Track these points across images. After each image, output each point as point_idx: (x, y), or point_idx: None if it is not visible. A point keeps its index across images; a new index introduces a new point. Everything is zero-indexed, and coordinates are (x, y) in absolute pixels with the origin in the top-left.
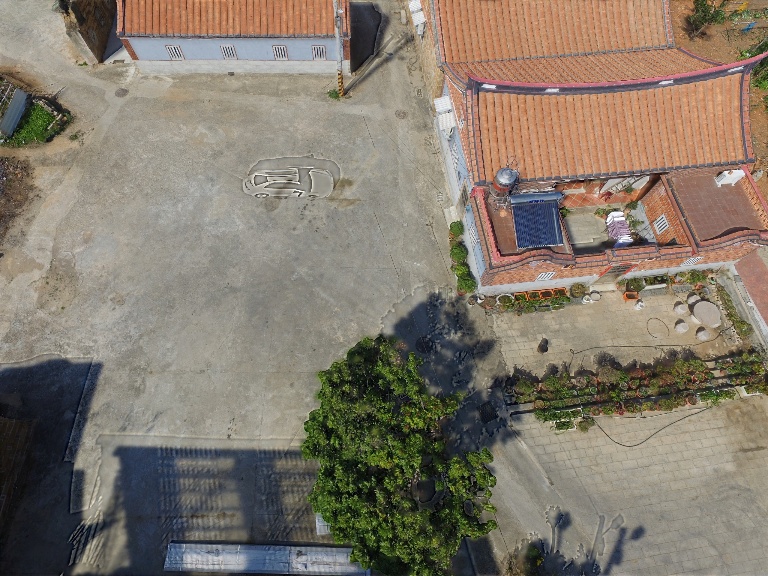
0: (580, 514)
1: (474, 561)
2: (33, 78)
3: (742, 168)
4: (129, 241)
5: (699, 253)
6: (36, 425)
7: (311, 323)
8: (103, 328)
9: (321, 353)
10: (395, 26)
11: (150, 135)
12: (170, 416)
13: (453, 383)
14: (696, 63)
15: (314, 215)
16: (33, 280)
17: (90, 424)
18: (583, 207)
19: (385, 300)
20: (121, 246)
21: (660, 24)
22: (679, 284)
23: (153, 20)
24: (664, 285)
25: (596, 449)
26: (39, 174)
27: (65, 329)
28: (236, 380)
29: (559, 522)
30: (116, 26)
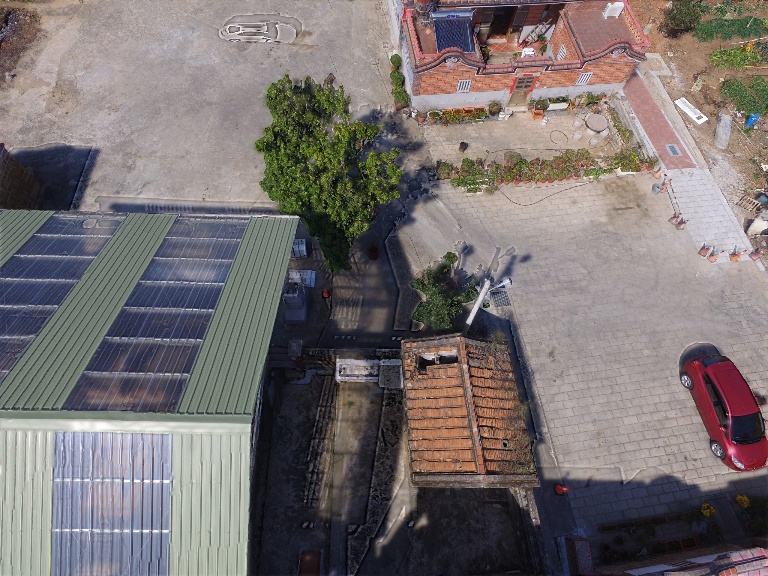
0: (481, 246)
1: (395, 274)
2: None
3: (624, 3)
4: (122, 69)
5: (586, 66)
6: (46, 188)
7: None
8: (100, 127)
9: None
10: None
11: None
12: (156, 185)
13: None
14: None
15: (279, 55)
16: (42, 93)
17: (90, 189)
18: (504, 52)
19: None
20: (115, 72)
21: None
22: (579, 107)
23: None
24: (565, 105)
25: (498, 206)
26: (45, 21)
27: (69, 127)
28: (210, 163)
29: (464, 251)
30: None
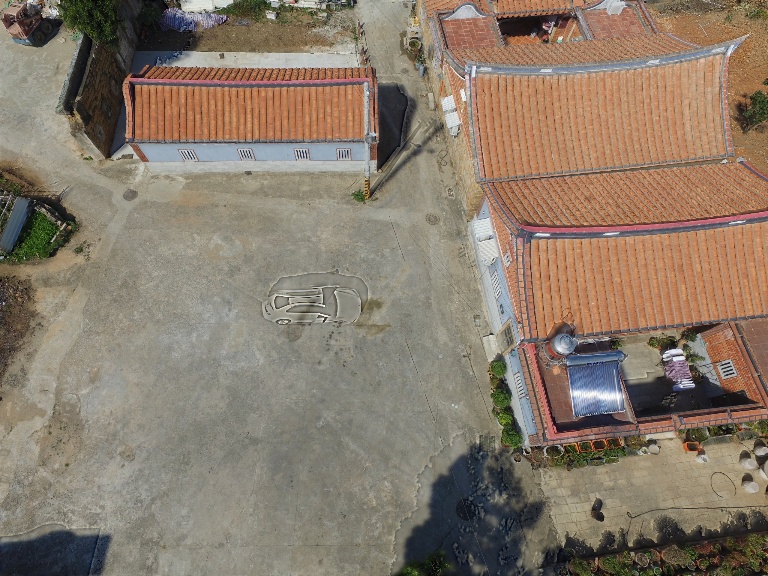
0: None
1: None
2: (35, 175)
3: None
4: (139, 380)
5: None
6: None
7: (340, 482)
8: (111, 490)
9: (352, 521)
10: (422, 112)
11: (161, 247)
12: None
13: (500, 560)
14: (766, 189)
15: (341, 345)
16: (34, 430)
17: None
18: (635, 335)
19: (421, 452)
20: (131, 386)
21: (719, 131)
22: (744, 430)
23: (165, 125)
24: (729, 435)
25: None
26: (41, 297)
27: (69, 492)
28: (259, 556)
29: None
30: (124, 113)
